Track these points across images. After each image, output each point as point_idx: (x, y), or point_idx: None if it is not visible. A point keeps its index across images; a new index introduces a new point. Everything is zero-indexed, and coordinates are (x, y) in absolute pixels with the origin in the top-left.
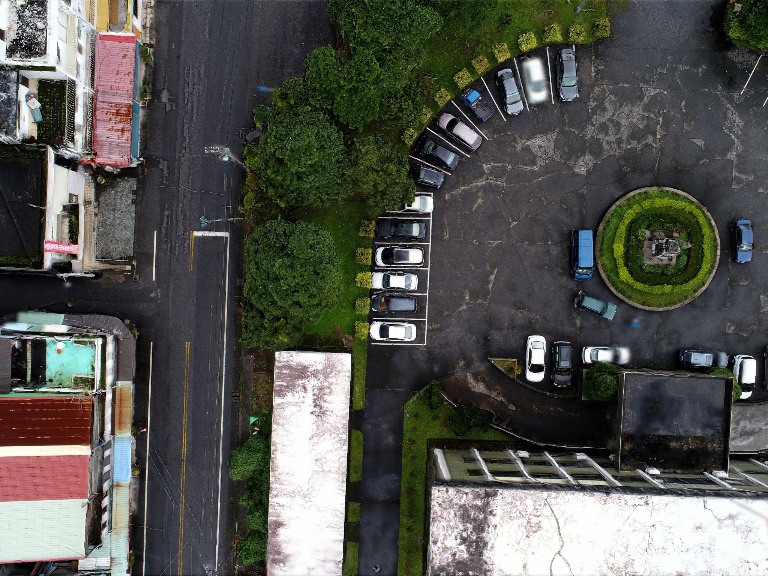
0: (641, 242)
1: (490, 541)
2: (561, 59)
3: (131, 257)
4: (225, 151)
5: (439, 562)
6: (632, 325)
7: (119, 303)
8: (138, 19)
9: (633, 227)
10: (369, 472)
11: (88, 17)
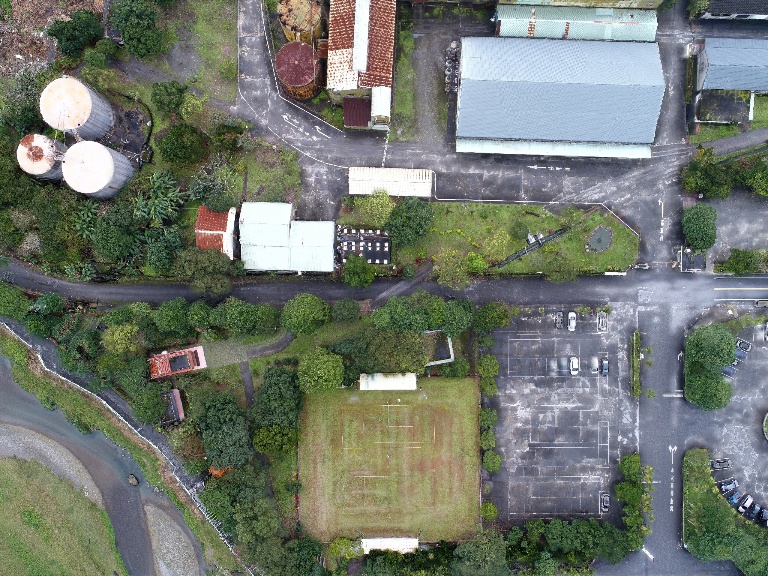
0: None
1: None
2: None
3: None
4: None
5: None
6: None
7: None
8: None
9: None
10: None
11: None
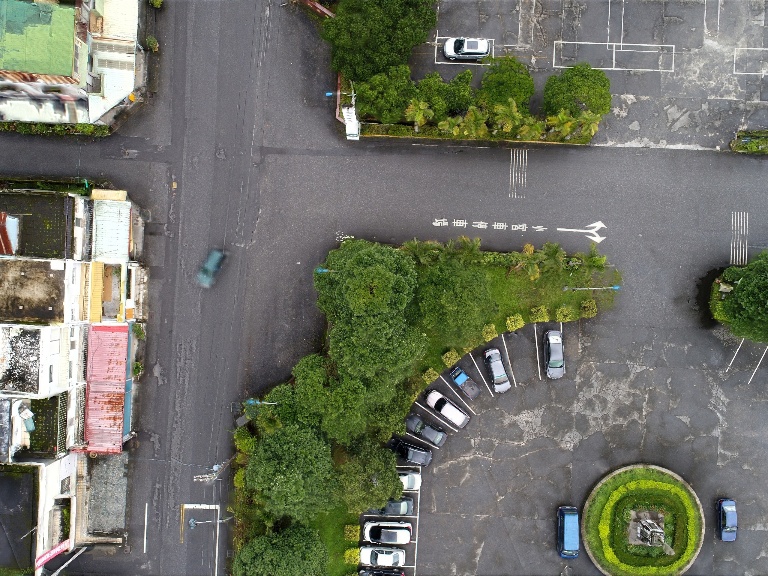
0: (626, 522)
1: None
2: (548, 341)
3: (122, 530)
4: None
5: None
6: None
7: (110, 574)
8: (131, 298)
9: (618, 509)
10: None
11: (81, 313)
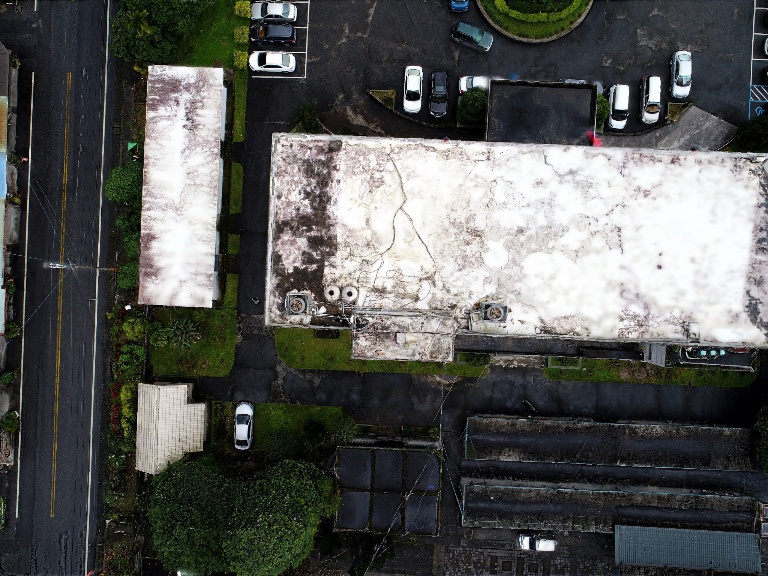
0: None
1: (333, 196)
2: None
3: None
4: None
5: (283, 217)
6: (510, 58)
7: (1, 33)
8: None
9: None
10: (249, 204)
11: None
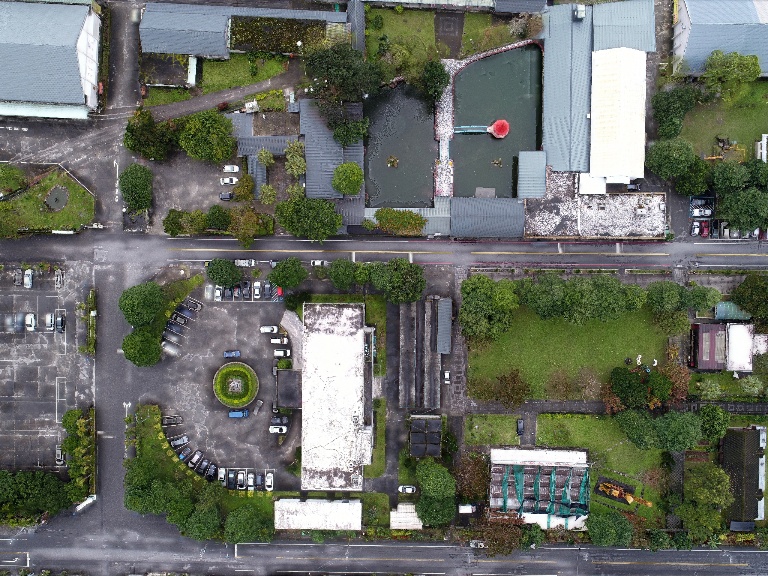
0: (233, 393)
1: (320, 469)
2: None
3: None
4: (201, 553)
5: (328, 485)
6: (265, 393)
7: None
8: None
9: None
10: None
11: None
